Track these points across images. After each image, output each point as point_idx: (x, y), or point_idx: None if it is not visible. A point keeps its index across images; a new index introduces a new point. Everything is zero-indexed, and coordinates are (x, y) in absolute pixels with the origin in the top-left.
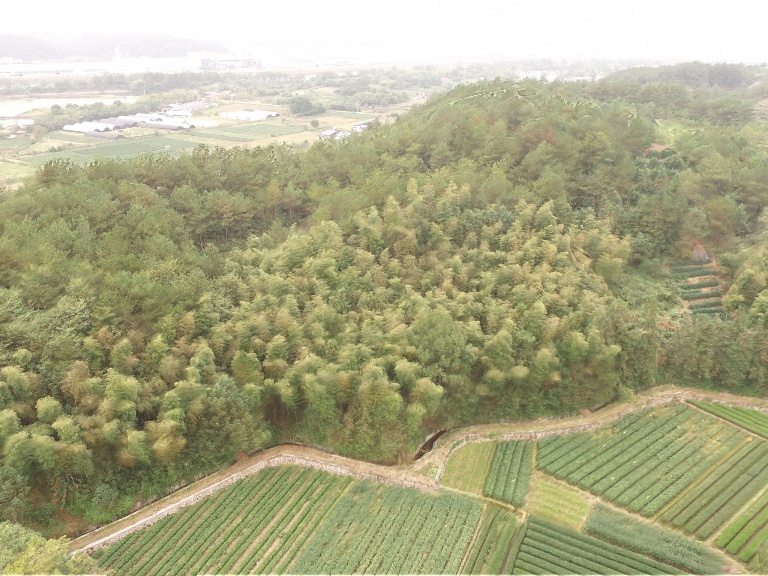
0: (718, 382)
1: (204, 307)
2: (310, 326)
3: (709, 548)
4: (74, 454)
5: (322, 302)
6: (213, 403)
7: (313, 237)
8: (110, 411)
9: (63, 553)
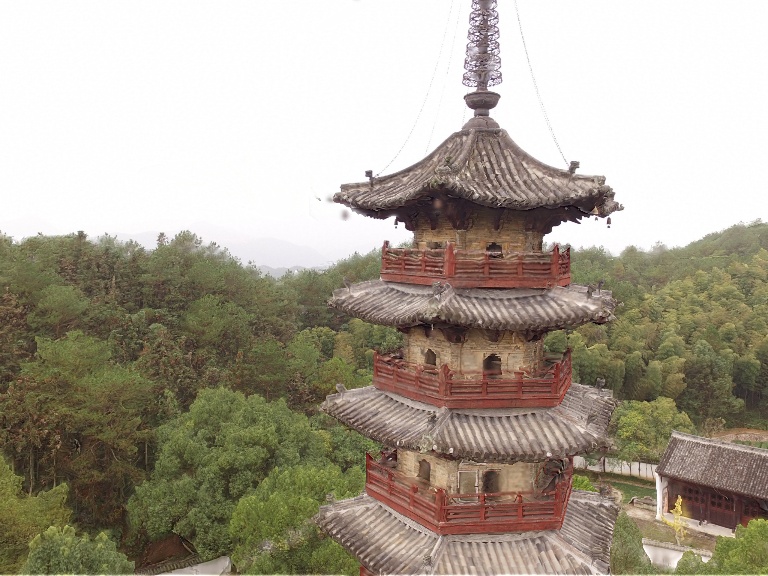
0: None
1: (652, 301)
2: (747, 324)
3: None
4: (611, 372)
5: (749, 308)
6: (701, 358)
7: (694, 282)
8: (626, 347)
9: (674, 407)
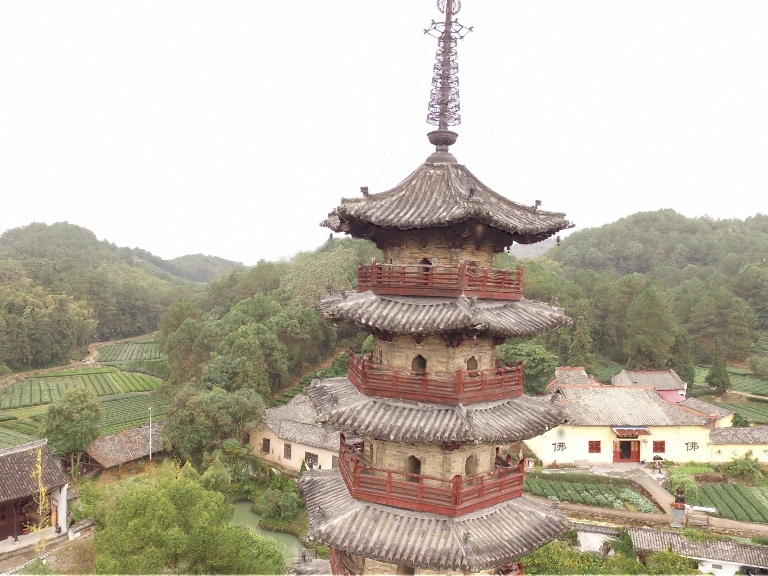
0: (35, 363)
1: None
2: None
3: (127, 393)
4: None
5: None
6: None
7: None
8: None
9: None
